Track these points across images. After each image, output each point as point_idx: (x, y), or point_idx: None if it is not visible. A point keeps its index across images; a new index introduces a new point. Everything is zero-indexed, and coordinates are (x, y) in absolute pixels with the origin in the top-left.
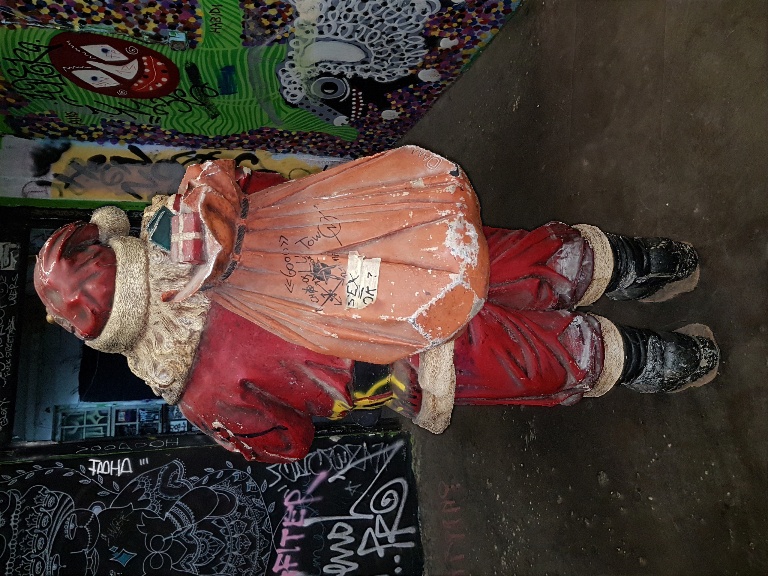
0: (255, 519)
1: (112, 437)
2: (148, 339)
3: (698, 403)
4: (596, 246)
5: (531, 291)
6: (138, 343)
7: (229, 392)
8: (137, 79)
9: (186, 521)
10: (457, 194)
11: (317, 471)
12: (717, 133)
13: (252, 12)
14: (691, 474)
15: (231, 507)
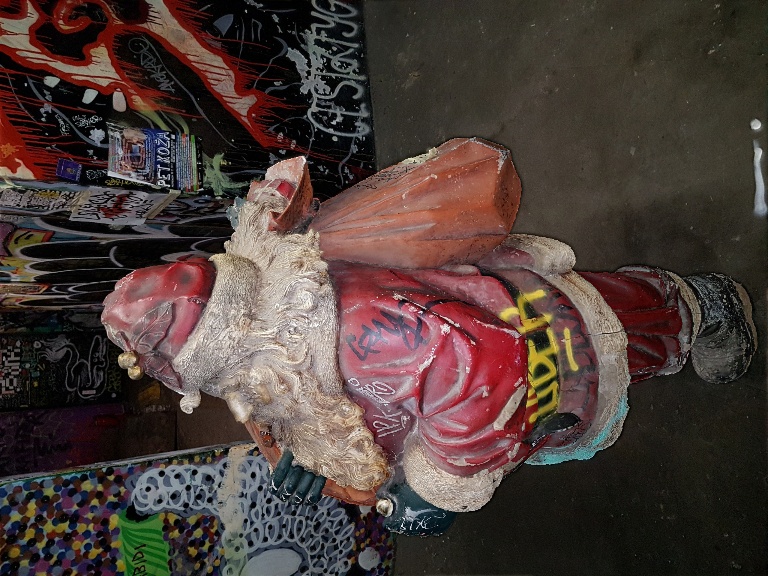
0: None
1: None
2: None
3: None
4: None
5: None
6: (258, 295)
7: None
8: None
9: None
10: None
11: None
12: None
13: (177, 543)
14: None
15: None
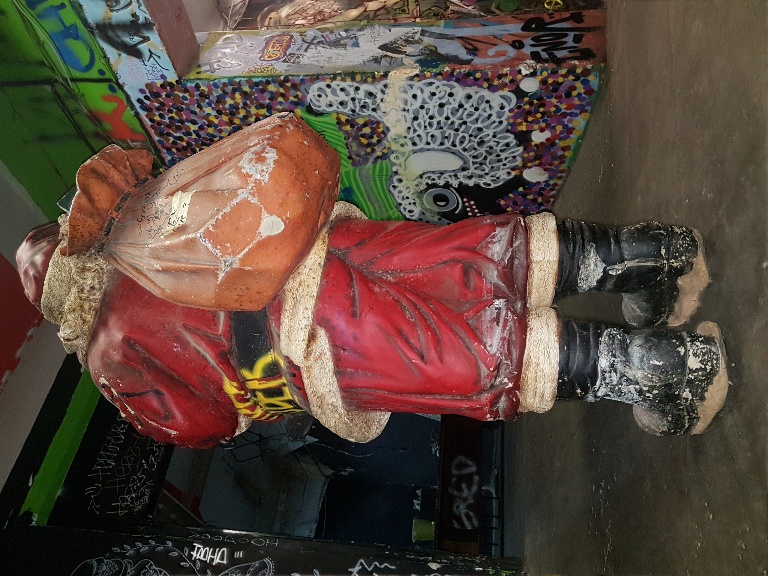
0: None
1: None
2: None
3: (728, 441)
4: (535, 226)
5: (453, 277)
6: None
7: (114, 349)
8: None
9: None
10: (274, 130)
11: None
12: (707, 94)
13: (351, 133)
14: (731, 554)
15: None
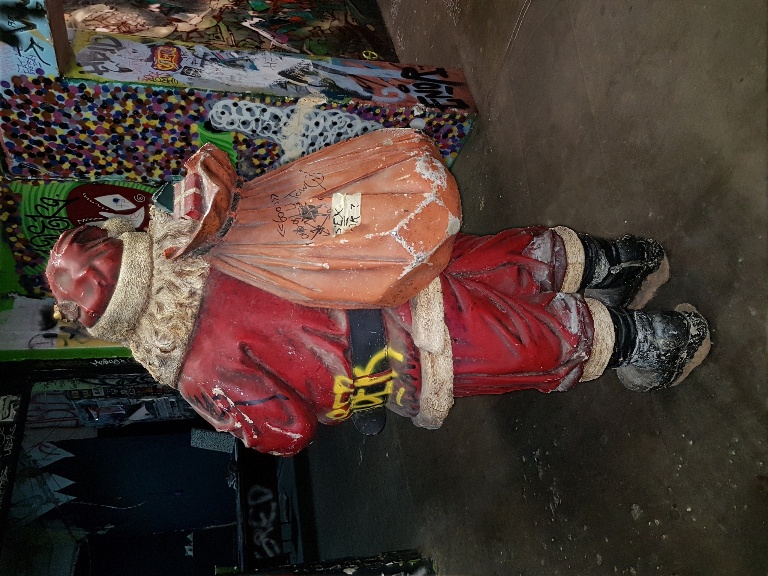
0: None
1: None
2: (150, 312)
3: (704, 385)
4: (564, 236)
5: (512, 277)
6: (141, 319)
7: (229, 356)
8: (143, 227)
9: None
10: (422, 143)
11: None
12: (649, 146)
13: (244, 153)
14: (720, 462)
15: None
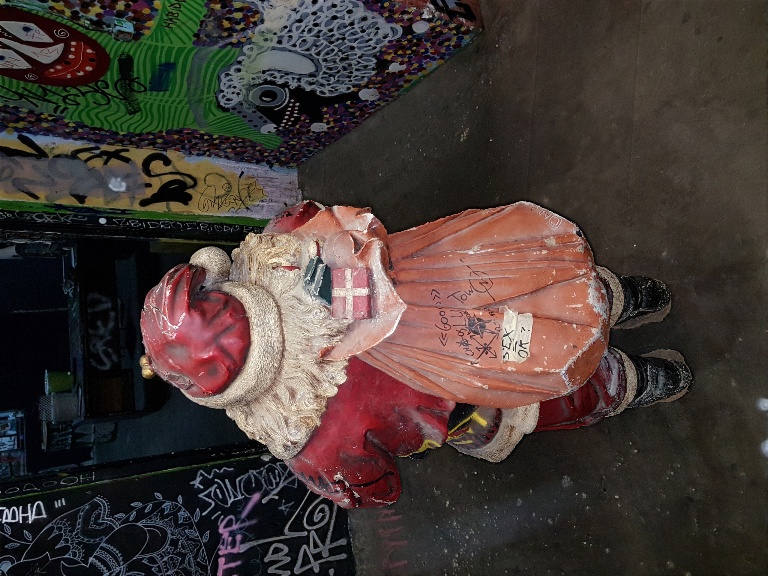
0: (189, 552)
1: (12, 478)
2: (274, 394)
3: (664, 415)
4: (612, 286)
5: None
6: (261, 398)
7: (353, 443)
8: (56, 64)
9: (113, 564)
10: (586, 254)
11: (250, 493)
12: (687, 191)
13: (215, 12)
14: (657, 475)
15: (163, 542)
